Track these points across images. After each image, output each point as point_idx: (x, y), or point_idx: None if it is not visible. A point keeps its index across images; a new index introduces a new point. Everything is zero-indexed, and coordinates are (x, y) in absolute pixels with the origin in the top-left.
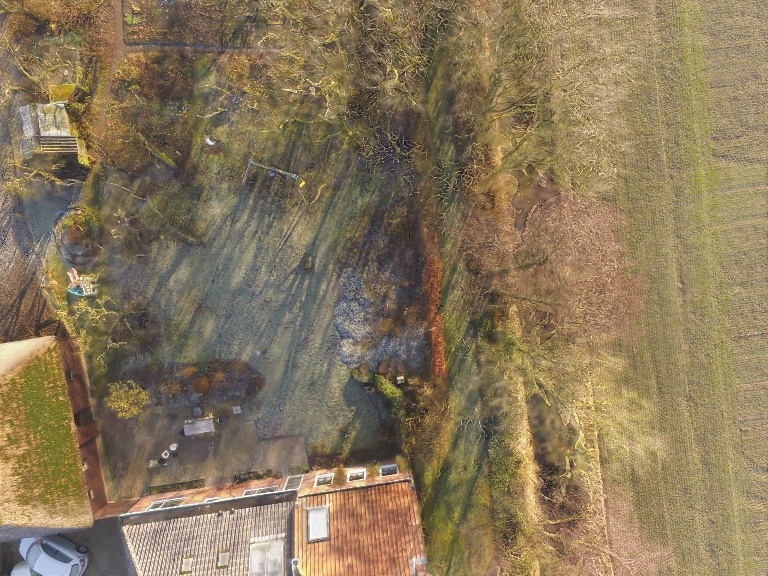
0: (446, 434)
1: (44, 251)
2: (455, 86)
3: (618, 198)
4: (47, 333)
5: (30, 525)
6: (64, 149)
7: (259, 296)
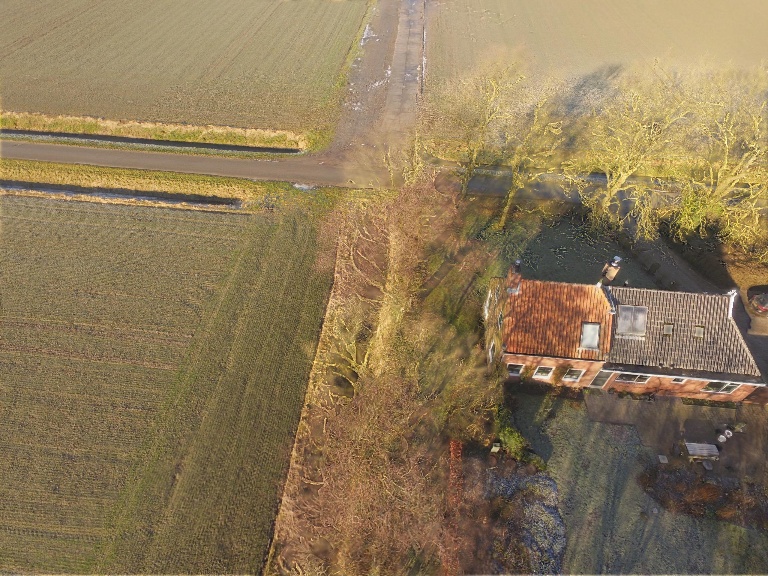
0: (452, 391)
1: None
2: None
3: None
4: None
5: None
6: None
7: None
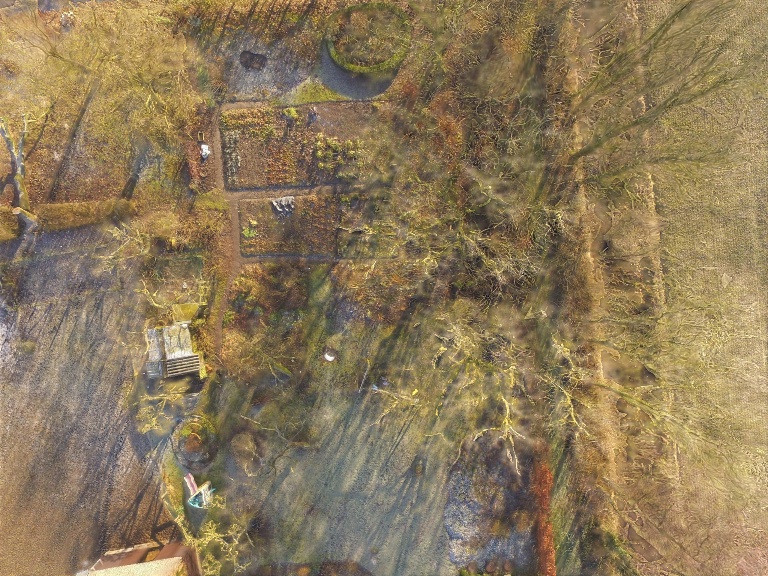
0: None
1: (161, 457)
2: (562, 292)
3: (719, 398)
4: (163, 536)
5: None
6: (188, 369)
7: (371, 499)
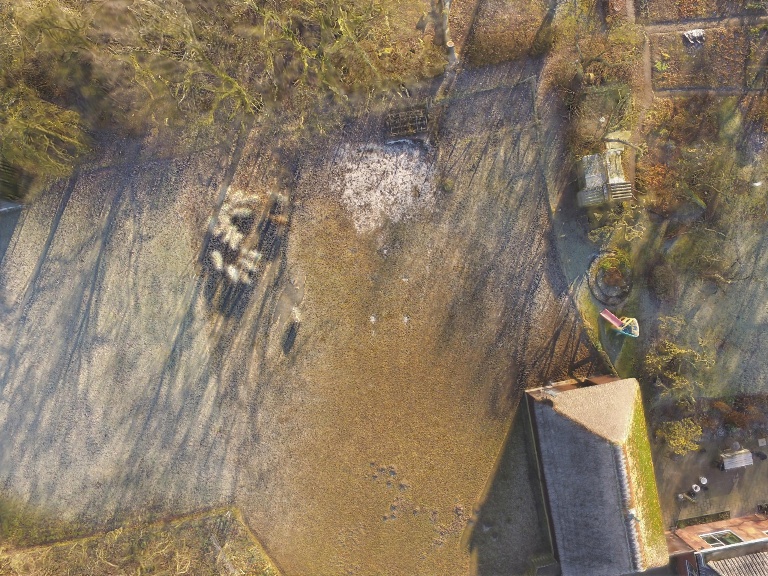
0: None
1: (577, 293)
2: None
3: None
4: (580, 373)
5: (652, 566)
6: (624, 195)
7: None
